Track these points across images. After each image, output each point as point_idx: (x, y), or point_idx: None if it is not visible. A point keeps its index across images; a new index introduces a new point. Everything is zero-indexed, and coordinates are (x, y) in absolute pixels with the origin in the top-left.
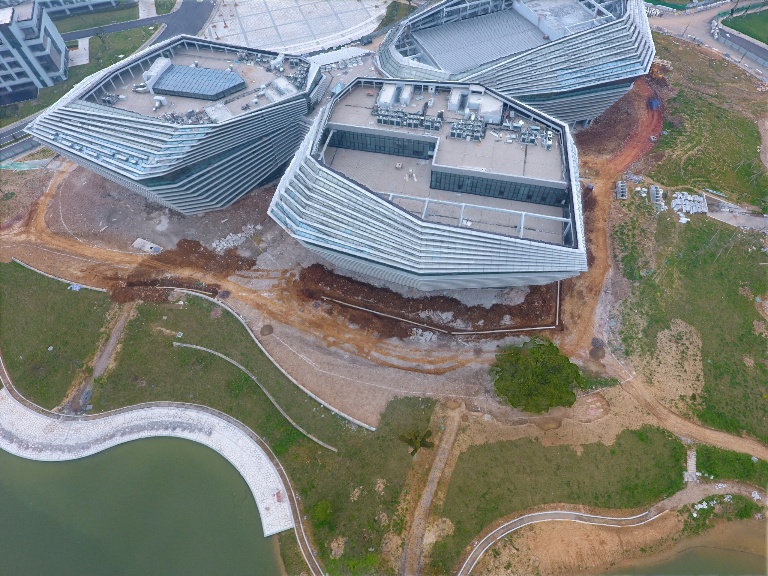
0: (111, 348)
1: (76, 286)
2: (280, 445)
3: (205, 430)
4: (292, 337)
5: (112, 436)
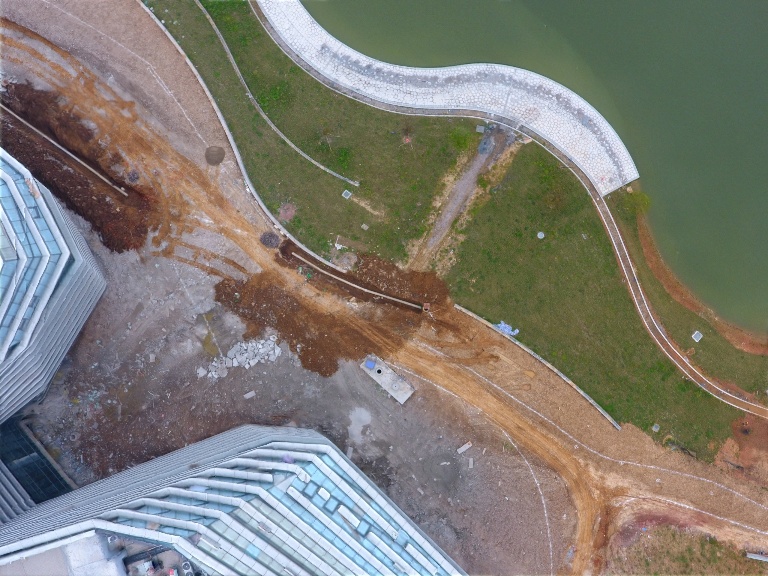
0: (450, 206)
1: (505, 331)
2: (235, 2)
3: (329, 54)
4: (179, 131)
5: (449, 80)
